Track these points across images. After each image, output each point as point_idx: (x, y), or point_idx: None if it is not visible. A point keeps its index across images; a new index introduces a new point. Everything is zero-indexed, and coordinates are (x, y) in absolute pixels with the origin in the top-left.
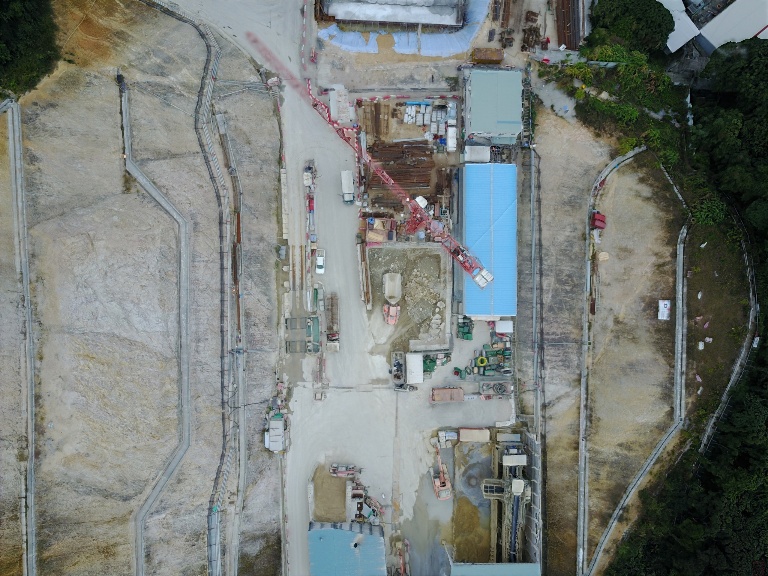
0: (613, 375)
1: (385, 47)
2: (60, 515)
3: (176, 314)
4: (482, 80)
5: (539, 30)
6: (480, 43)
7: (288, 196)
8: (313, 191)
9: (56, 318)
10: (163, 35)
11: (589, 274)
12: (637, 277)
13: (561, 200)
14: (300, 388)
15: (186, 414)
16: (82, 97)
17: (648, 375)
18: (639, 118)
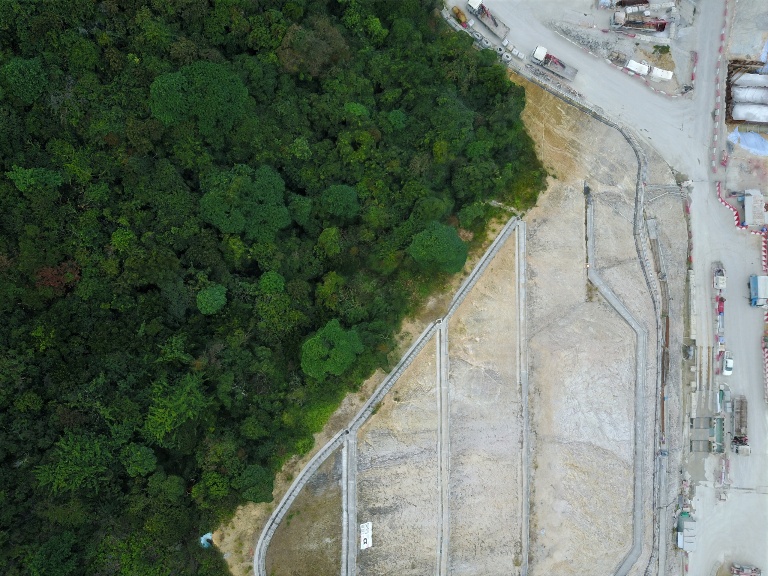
0: None
1: None
2: None
3: (633, 422)
4: None
5: None
6: None
7: (695, 297)
8: (721, 293)
9: (549, 428)
10: (600, 141)
11: None
12: None
13: None
14: (702, 487)
15: (639, 519)
16: (561, 210)
17: None
18: None
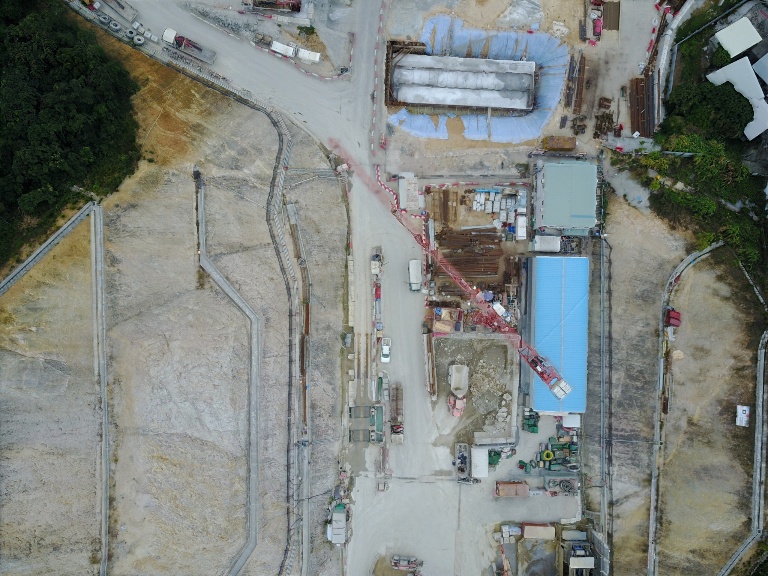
0: (686, 478)
1: (455, 133)
2: None
3: (246, 411)
4: (556, 173)
5: (612, 117)
6: (551, 129)
7: (354, 283)
8: (380, 278)
9: (132, 420)
10: (236, 125)
11: (662, 372)
12: (714, 379)
13: (633, 293)
14: (362, 477)
15: (254, 512)
16: (160, 195)
17: (724, 482)
18: (716, 211)
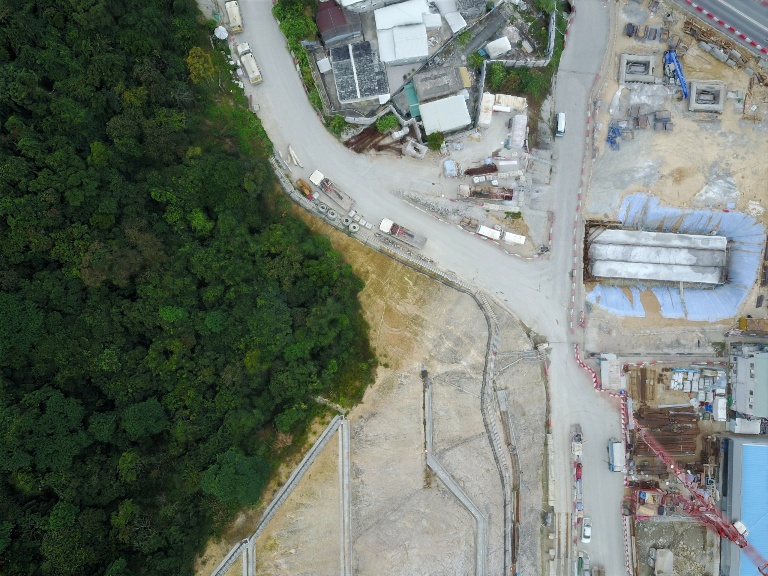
0: None
1: (652, 311)
2: None
3: None
4: (767, 365)
5: None
6: (748, 309)
7: (554, 461)
8: (579, 457)
9: None
10: (449, 312)
11: None
12: None
13: None
14: None
15: None
16: (394, 399)
17: None
18: None
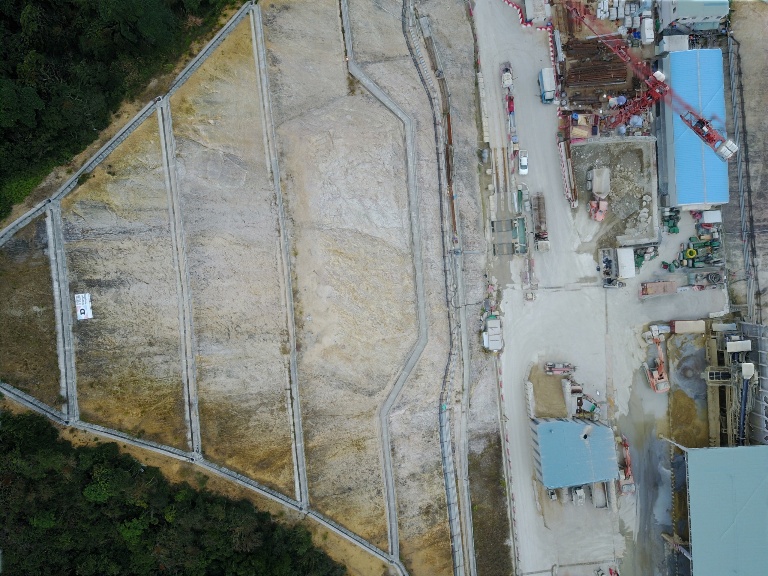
0: None
1: None
2: (319, 407)
3: (407, 211)
4: None
5: None
6: None
7: (486, 100)
8: (511, 93)
9: (306, 214)
10: None
11: None
12: None
13: (766, 84)
14: (509, 290)
15: (423, 309)
16: None
17: None
18: None
